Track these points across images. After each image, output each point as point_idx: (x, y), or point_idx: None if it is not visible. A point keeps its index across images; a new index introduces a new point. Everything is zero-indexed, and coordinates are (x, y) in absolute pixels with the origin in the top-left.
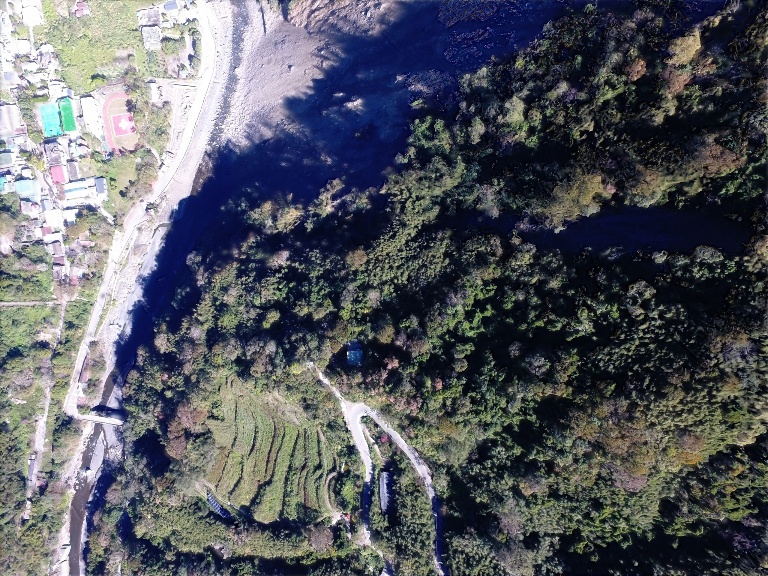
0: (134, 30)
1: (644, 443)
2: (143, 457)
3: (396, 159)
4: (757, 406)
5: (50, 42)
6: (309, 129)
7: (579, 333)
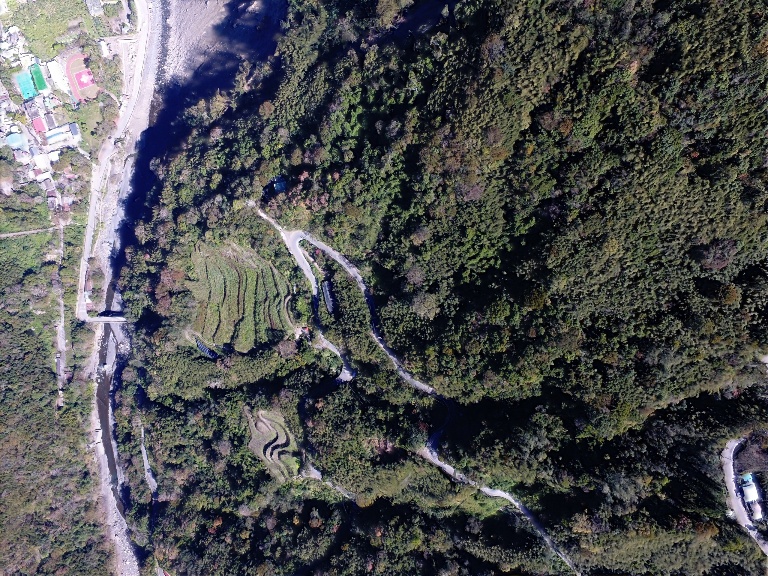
0: (80, 3)
1: (468, 152)
2: (143, 328)
3: (281, 26)
4: (518, 85)
5: (15, 24)
6: (227, 42)
7: (414, 93)
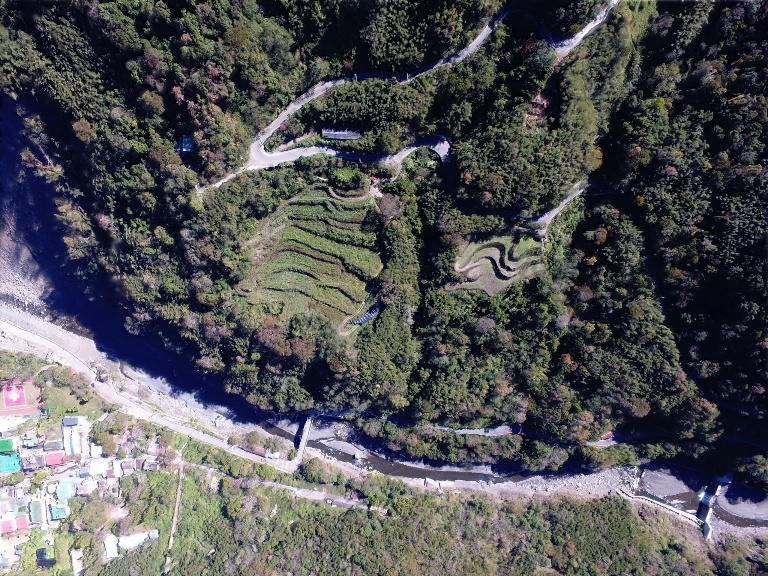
0: None
1: None
2: None
3: None
4: None
5: None
6: (4, 200)
7: None
